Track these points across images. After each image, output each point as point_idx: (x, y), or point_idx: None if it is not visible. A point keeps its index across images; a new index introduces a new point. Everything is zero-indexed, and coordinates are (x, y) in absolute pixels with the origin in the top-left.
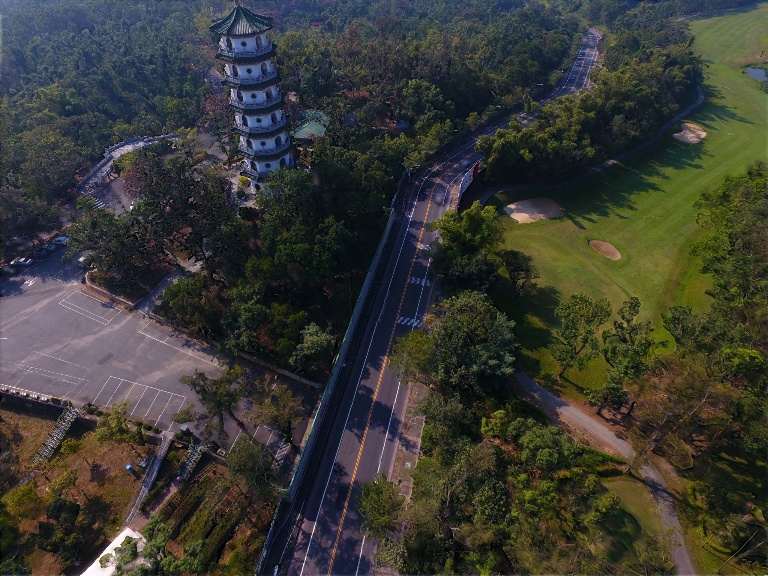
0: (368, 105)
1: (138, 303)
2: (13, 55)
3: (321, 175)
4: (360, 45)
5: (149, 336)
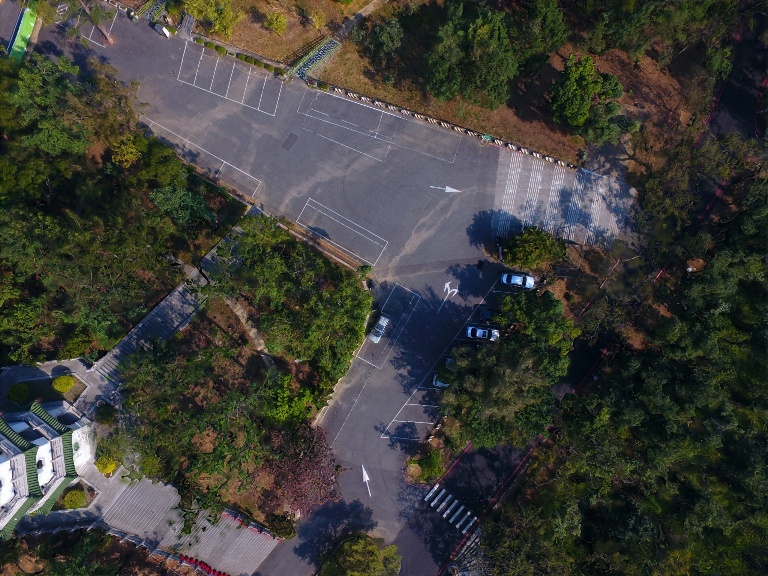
0: None
1: None
2: None
3: None
4: None
5: (246, 174)
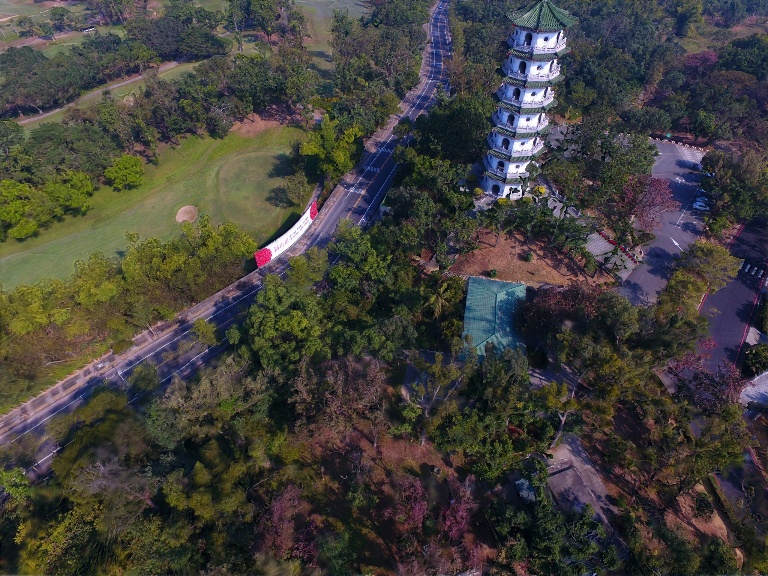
0: (394, 318)
1: None
2: None
3: None
4: None
5: None
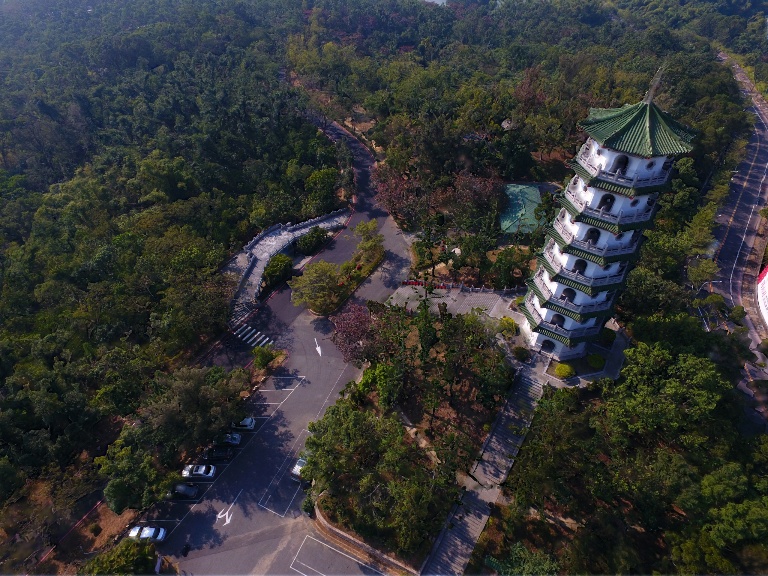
0: None
1: (424, 568)
2: (77, 102)
3: (699, 349)
4: (535, 90)
5: None
